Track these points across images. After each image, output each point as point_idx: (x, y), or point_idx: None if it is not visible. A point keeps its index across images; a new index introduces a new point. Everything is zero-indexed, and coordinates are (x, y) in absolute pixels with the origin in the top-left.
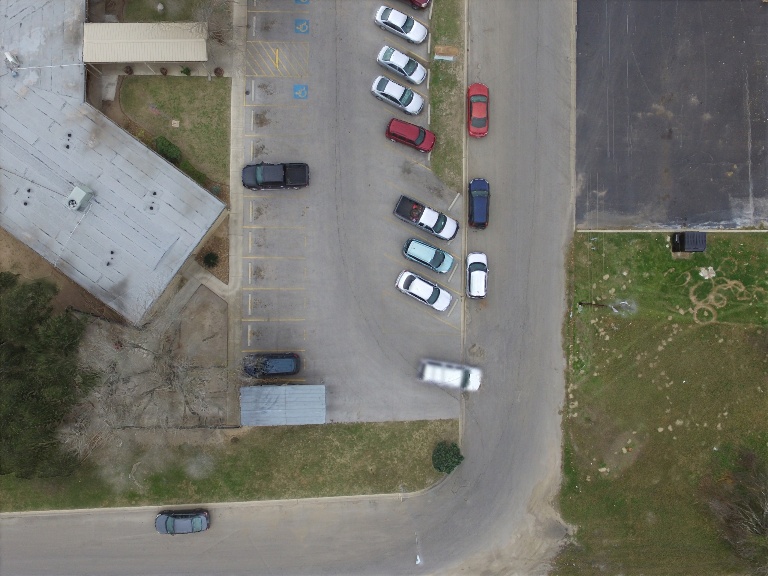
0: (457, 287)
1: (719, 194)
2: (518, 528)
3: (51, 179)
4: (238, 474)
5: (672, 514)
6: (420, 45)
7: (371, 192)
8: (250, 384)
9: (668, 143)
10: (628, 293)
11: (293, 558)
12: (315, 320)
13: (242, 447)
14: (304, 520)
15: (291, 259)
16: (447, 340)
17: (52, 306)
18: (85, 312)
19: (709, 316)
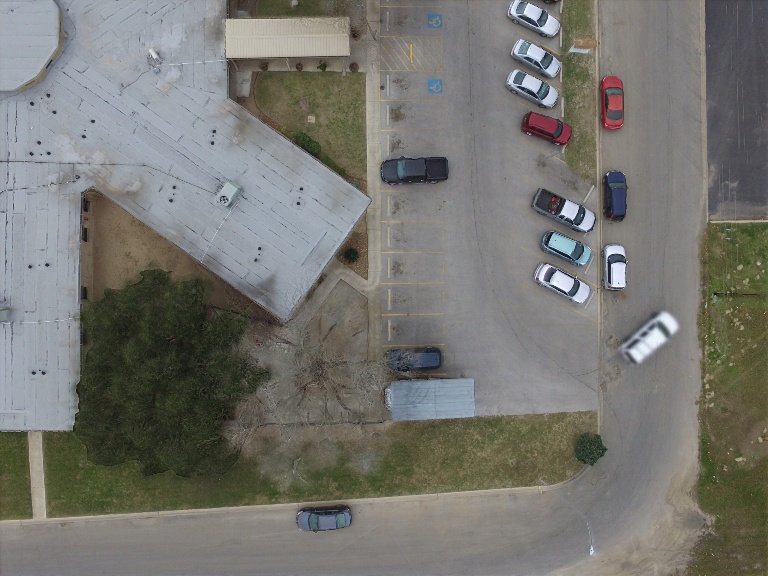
0: (593, 279)
1: None
2: (657, 519)
3: (197, 175)
4: (379, 469)
5: None
6: (552, 39)
7: (507, 185)
8: (393, 379)
9: None
10: (762, 283)
11: (434, 553)
12: (454, 314)
13: (383, 442)
14: (444, 515)
15: (429, 253)
16: (584, 332)
17: (205, 303)
18: (225, 309)
19: None
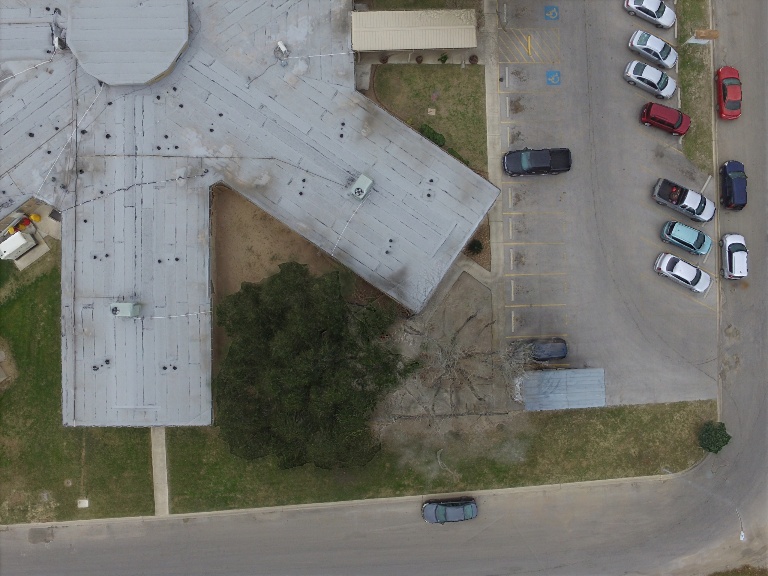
0: (712, 268)
1: None
2: None
3: (327, 168)
4: (503, 461)
5: None
6: (668, 30)
7: (626, 176)
8: None
9: None
10: None
11: (558, 543)
12: (576, 304)
13: (508, 433)
14: (568, 505)
15: (551, 244)
16: (704, 321)
17: None
18: (349, 302)
19: None
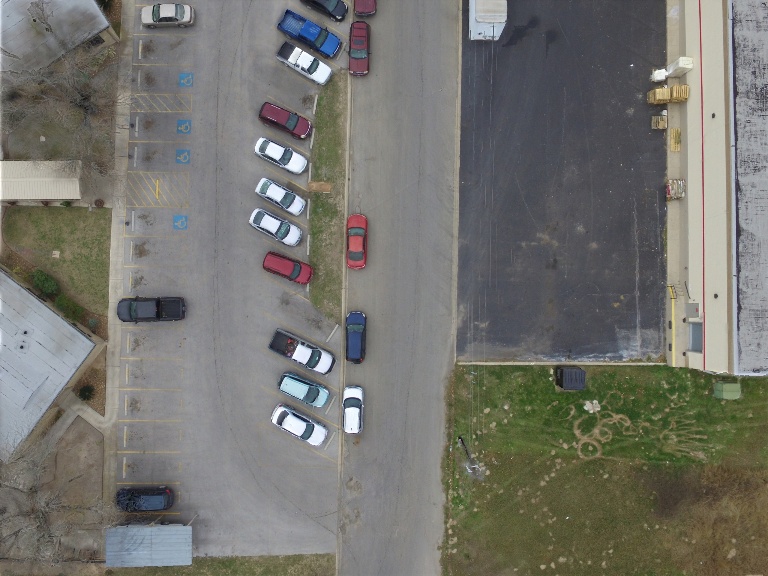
0: (334, 420)
1: (605, 325)
2: None
3: None
4: None
5: None
6: (300, 175)
7: (249, 323)
8: (123, 518)
9: (552, 273)
10: (509, 427)
11: None
12: (191, 452)
13: None
14: None
15: (167, 391)
16: (324, 473)
17: None
18: None
19: (594, 451)
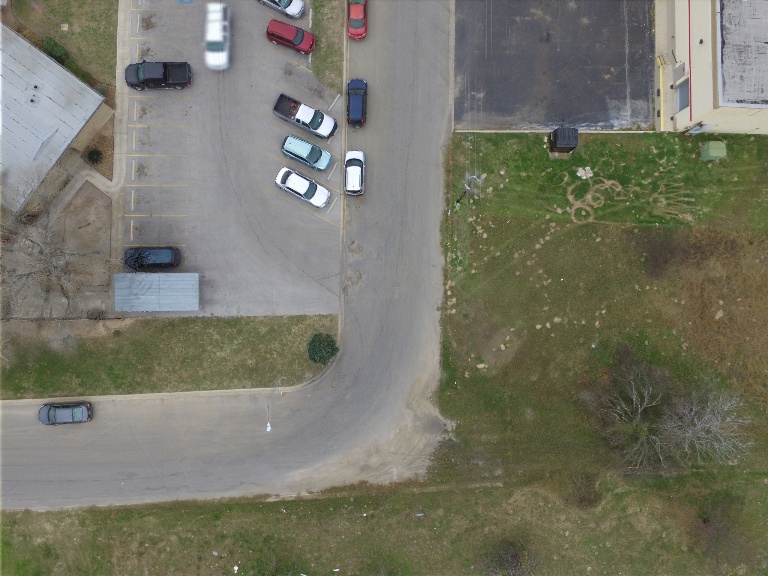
0: (337, 185)
1: (596, 96)
2: (397, 423)
3: None
4: (121, 367)
5: (551, 411)
6: None
7: (253, 93)
8: None
9: (546, 47)
10: (506, 192)
11: (174, 451)
12: (197, 216)
13: (124, 340)
14: (185, 413)
15: (174, 157)
16: (327, 237)
17: None
18: None
19: (587, 215)
